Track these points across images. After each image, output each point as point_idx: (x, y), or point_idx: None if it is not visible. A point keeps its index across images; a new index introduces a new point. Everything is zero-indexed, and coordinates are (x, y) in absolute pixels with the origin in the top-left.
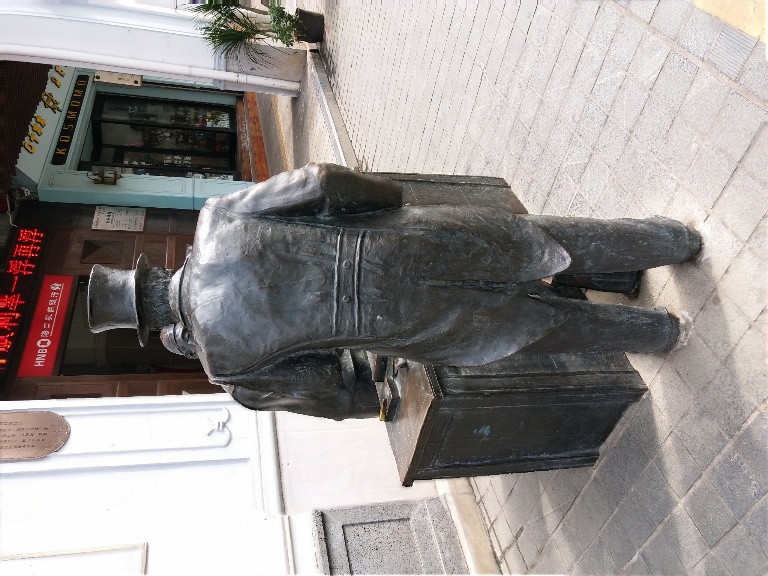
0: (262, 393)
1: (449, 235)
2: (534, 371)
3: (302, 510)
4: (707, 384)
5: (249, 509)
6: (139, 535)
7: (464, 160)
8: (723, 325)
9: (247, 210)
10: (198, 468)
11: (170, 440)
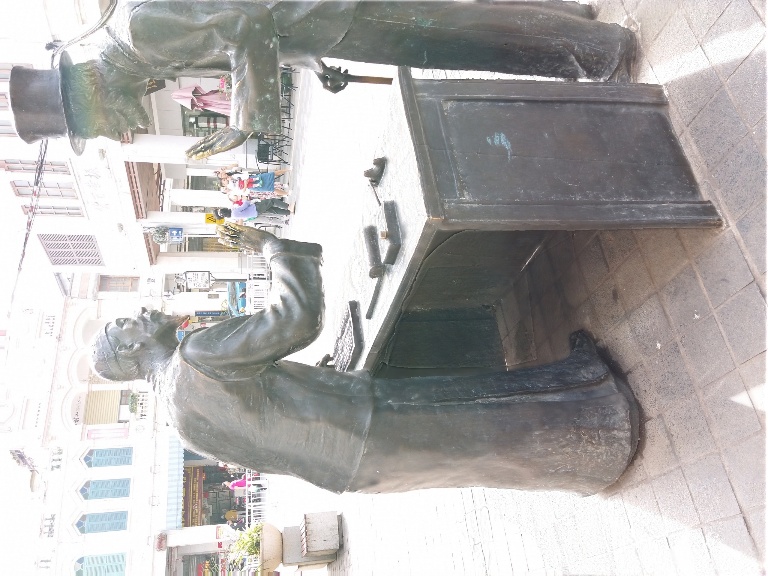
0: (223, 336)
1: None
2: None
3: None
4: None
5: None
6: None
7: None
8: None
9: None
10: None
11: None
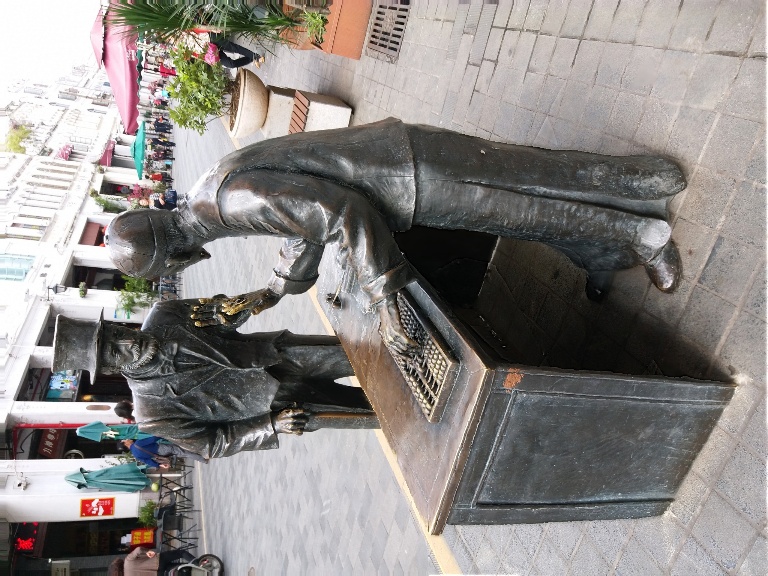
0: None
1: None
2: None
3: None
4: None
5: None
6: None
7: None
8: None
9: None
10: None
11: None
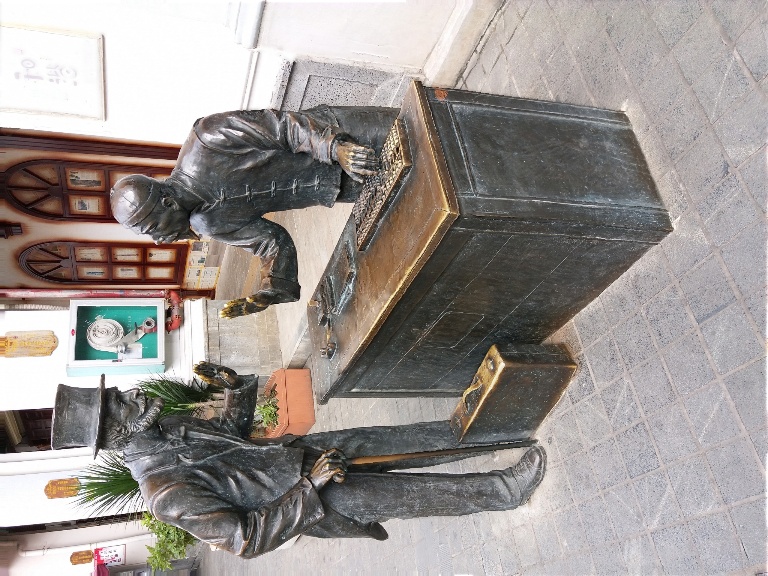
0: None
1: None
2: None
3: (276, 44)
4: None
5: (219, 25)
6: (93, 24)
7: None
8: None
9: None
10: None
11: None
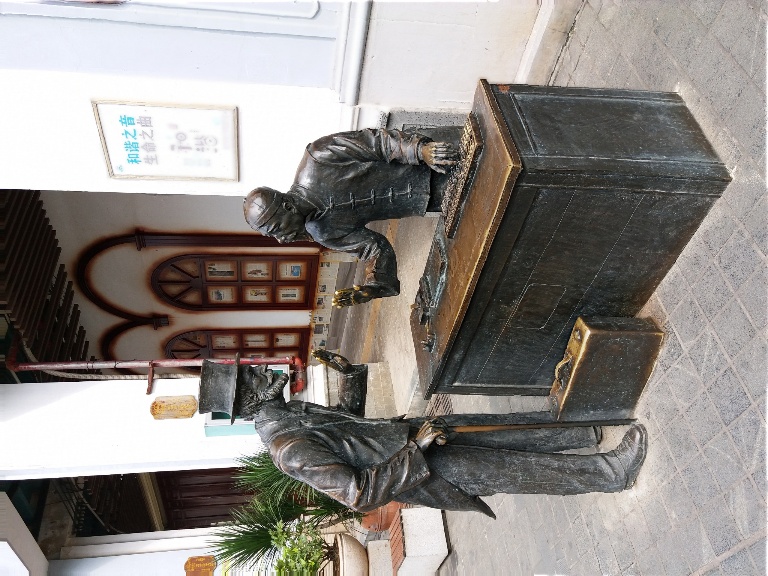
0: None
1: None
2: (509, 384)
3: (374, 100)
4: None
5: None
6: (229, 99)
7: None
8: None
9: None
10: (282, 40)
11: (252, 2)
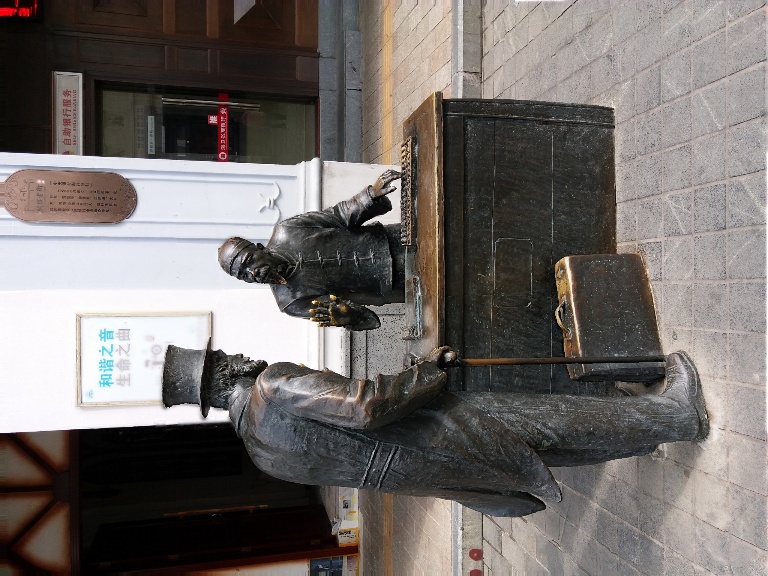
0: (307, 317)
1: (468, 463)
2: None
3: None
4: (648, 493)
5: None
6: (205, 304)
7: (591, 7)
8: (680, 489)
9: (297, 415)
10: None
11: (226, 214)
